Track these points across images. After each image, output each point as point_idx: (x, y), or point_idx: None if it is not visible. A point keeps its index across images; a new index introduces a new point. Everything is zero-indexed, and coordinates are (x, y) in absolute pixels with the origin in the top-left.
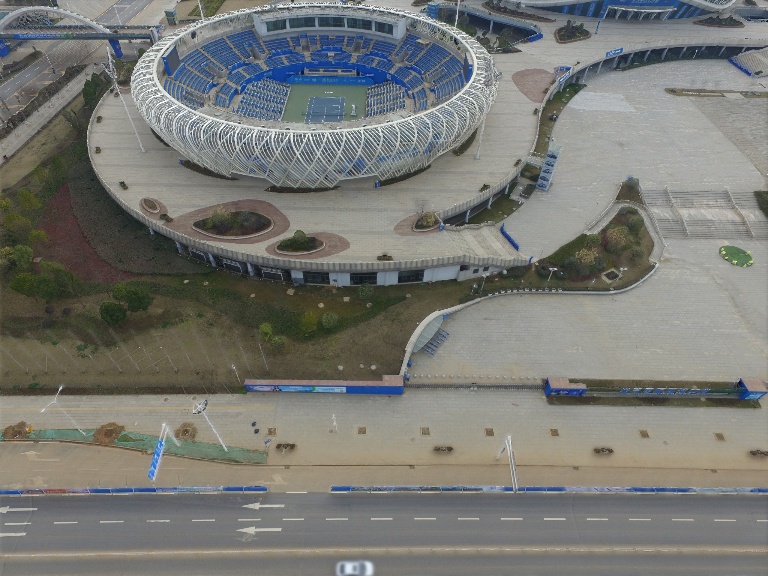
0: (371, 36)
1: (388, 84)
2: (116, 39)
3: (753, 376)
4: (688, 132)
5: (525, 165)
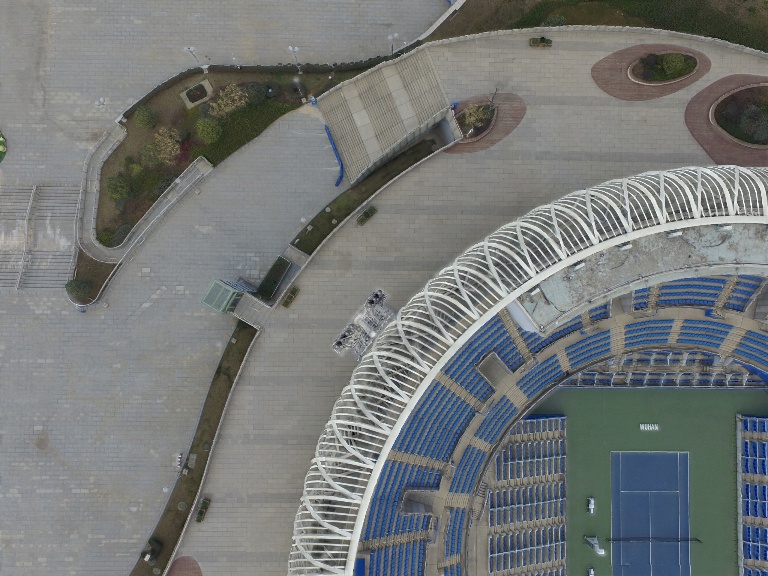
0: None
1: None
2: None
3: None
4: None
5: None
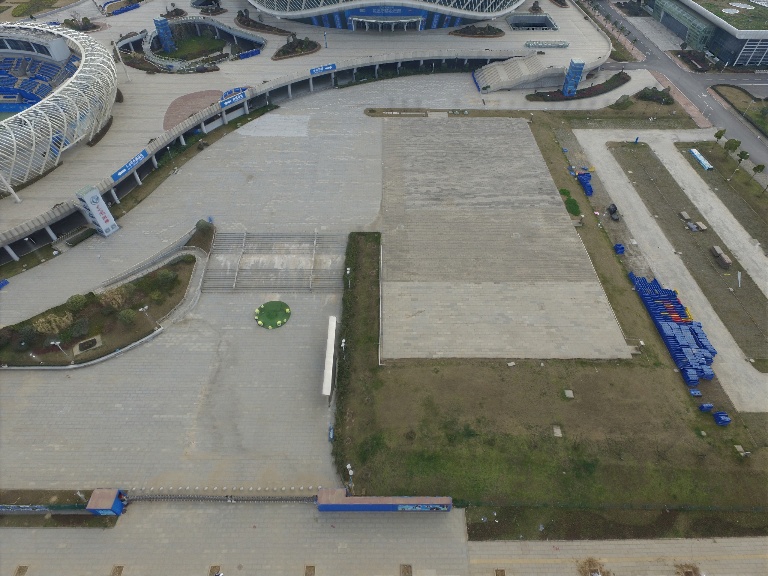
0: (40, 58)
1: None
2: None
3: (144, 480)
4: (342, 160)
5: (73, 208)
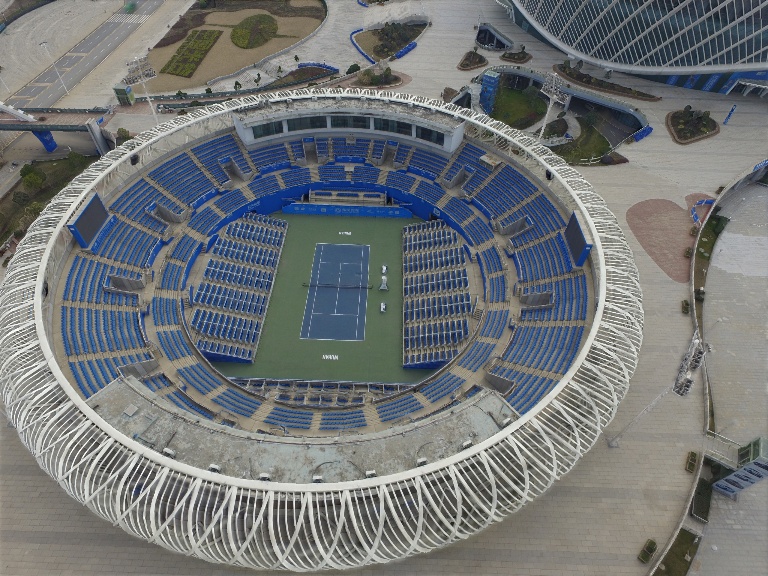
0: (409, 142)
1: (435, 225)
2: (42, 130)
3: None
4: None
5: None
